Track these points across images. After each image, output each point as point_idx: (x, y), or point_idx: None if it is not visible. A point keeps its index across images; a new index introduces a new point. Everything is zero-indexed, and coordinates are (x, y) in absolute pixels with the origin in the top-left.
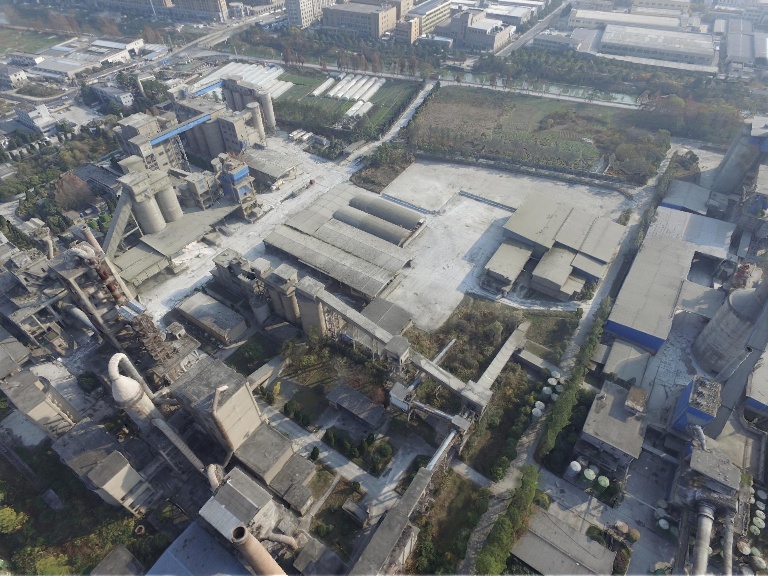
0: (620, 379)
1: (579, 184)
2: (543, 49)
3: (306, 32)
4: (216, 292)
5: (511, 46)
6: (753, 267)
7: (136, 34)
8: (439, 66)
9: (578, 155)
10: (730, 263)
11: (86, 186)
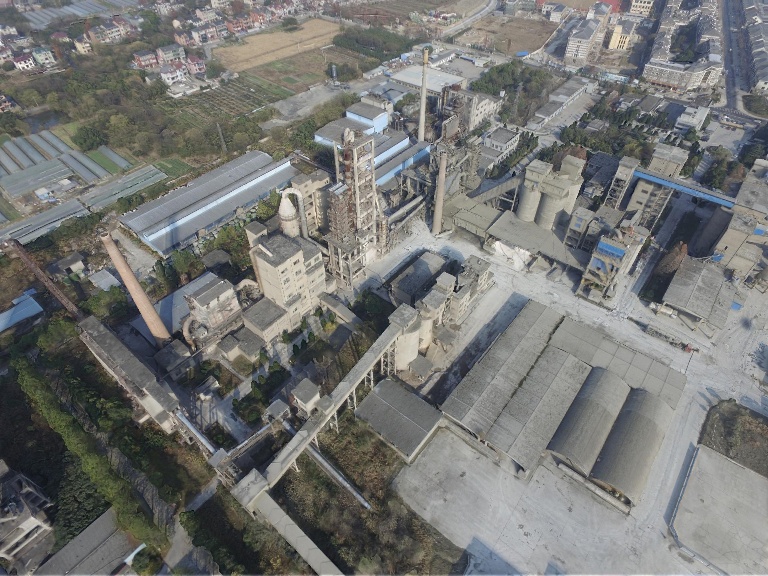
0: None
1: None
2: None
3: None
4: None
5: None
6: None
7: None
8: None
9: None
10: None
11: (593, 169)
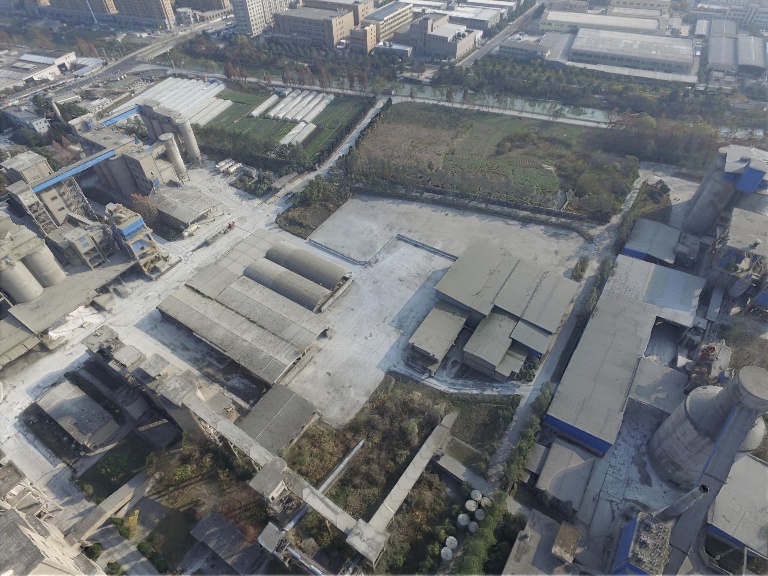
0: (555, 498)
1: (533, 223)
2: (509, 57)
3: (256, 41)
4: (94, 375)
5: (476, 53)
6: (721, 346)
7: (72, 45)
8: (395, 78)
9: (532, 190)
10: (697, 329)
11: None
